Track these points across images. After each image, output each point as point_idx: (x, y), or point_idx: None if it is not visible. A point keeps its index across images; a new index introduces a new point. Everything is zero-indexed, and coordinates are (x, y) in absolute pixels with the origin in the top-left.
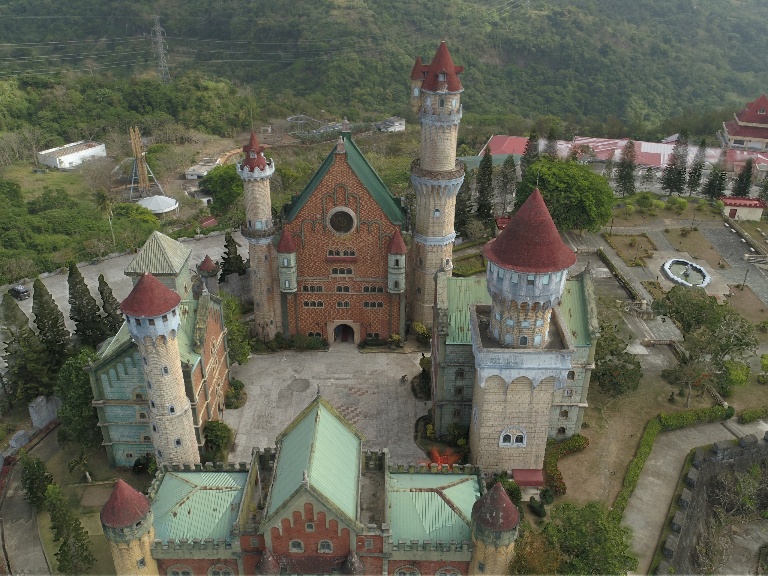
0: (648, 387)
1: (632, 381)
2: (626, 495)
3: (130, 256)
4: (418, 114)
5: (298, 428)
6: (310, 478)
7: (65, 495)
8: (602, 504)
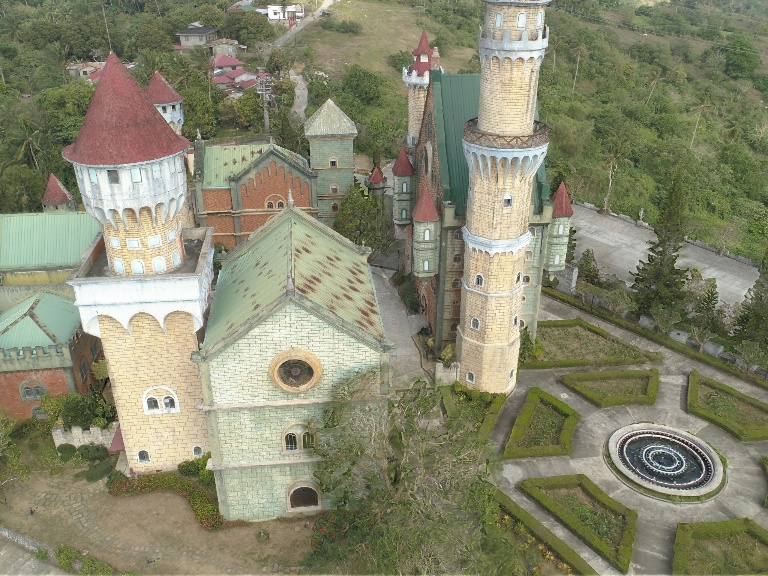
0: None
1: (322, 566)
2: (107, 575)
3: None
4: None
5: None
6: (7, 216)
7: None
8: (95, 542)
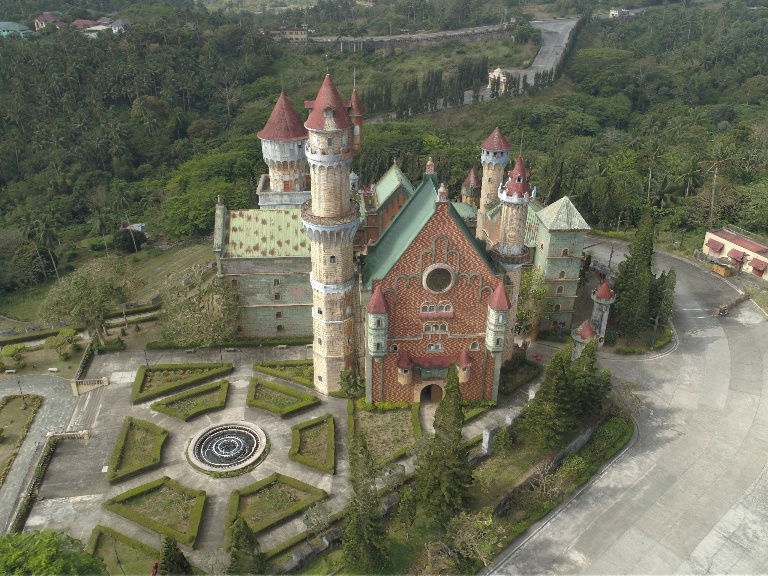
0: (147, 339)
1: None
2: None
3: None
4: None
5: None
6: None
7: None
8: None
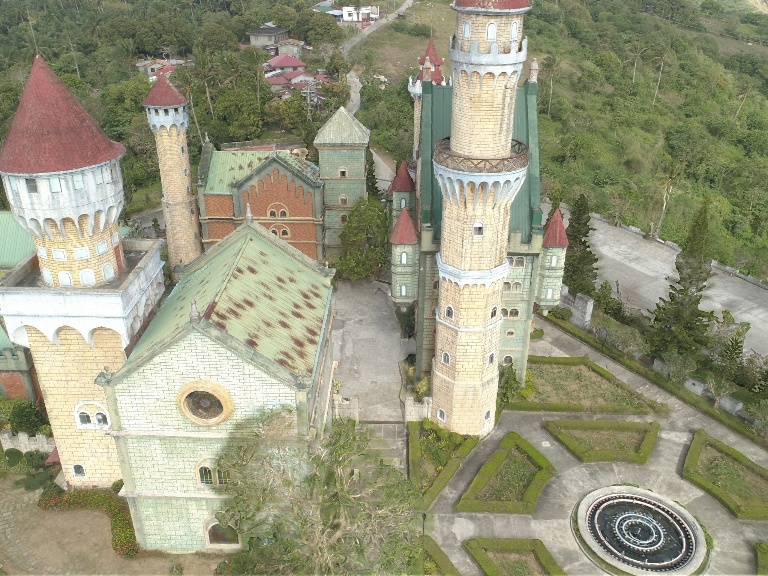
0: None
1: None
2: None
3: (604, 224)
4: None
5: None
6: None
7: None
8: (11, 556)
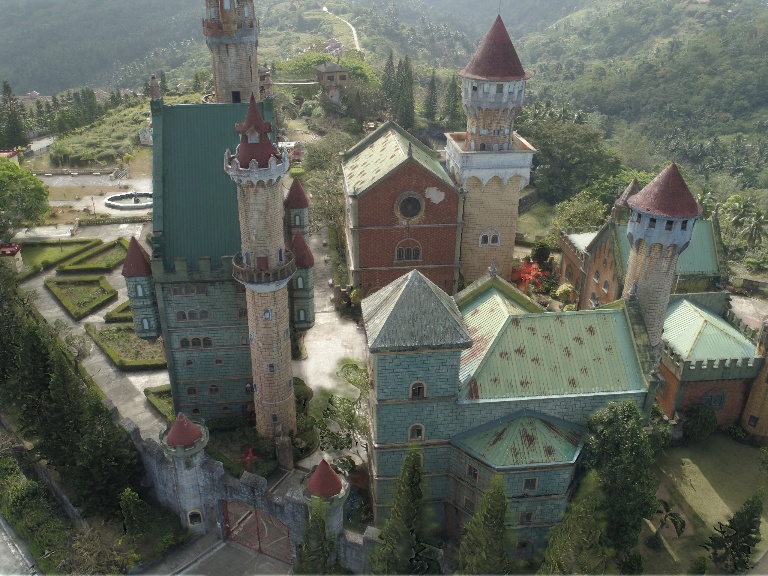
0: None
1: None
2: None
3: None
4: (238, 33)
5: (628, 252)
6: None
7: (694, 558)
8: None
